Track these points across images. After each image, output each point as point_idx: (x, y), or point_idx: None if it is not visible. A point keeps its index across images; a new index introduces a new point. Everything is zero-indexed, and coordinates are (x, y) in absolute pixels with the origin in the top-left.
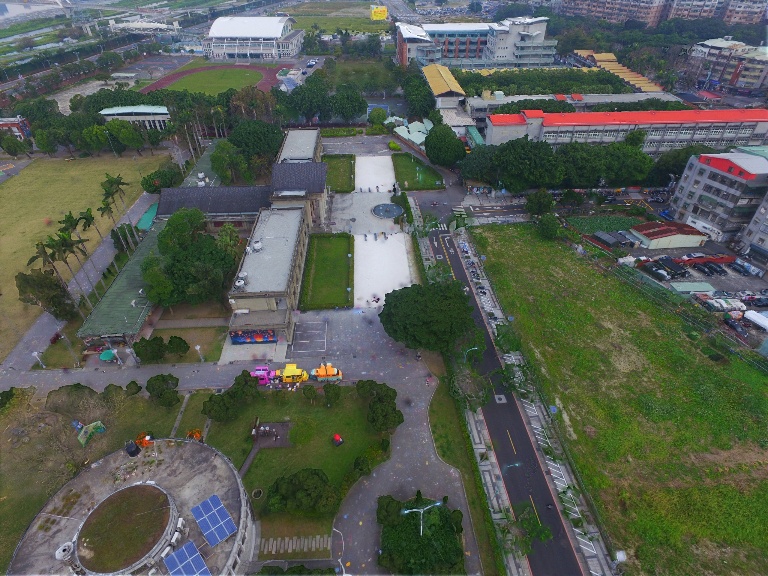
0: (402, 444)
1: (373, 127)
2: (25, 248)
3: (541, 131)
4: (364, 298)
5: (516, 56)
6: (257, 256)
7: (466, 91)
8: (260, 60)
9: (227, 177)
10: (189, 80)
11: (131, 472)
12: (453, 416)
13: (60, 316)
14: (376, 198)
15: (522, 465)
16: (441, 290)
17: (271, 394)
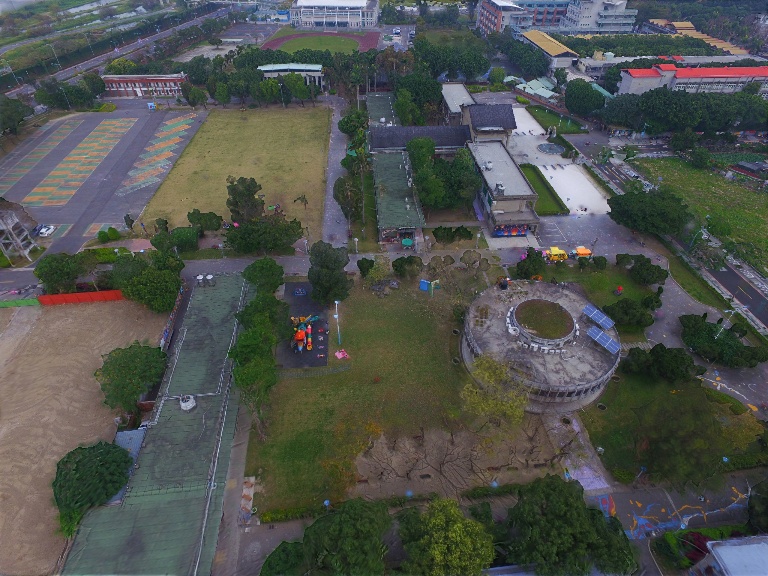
0: (665, 294)
1: (494, 85)
2: (268, 175)
3: (673, 82)
4: (573, 208)
5: (599, 24)
6: (491, 173)
7: (578, 53)
8: (347, 28)
9: (408, 121)
10: (292, 45)
11: (511, 297)
12: (693, 278)
13: (354, 216)
14: (534, 140)
15: (760, 305)
16: (654, 195)
17: (546, 267)
